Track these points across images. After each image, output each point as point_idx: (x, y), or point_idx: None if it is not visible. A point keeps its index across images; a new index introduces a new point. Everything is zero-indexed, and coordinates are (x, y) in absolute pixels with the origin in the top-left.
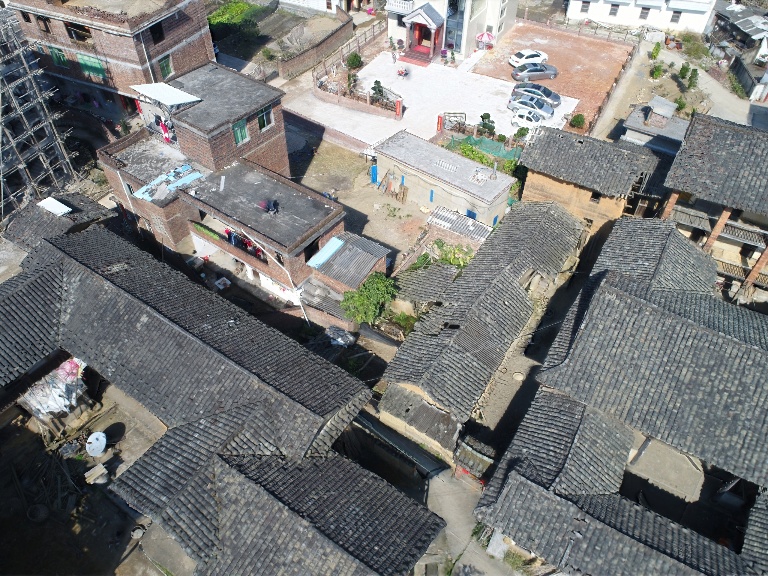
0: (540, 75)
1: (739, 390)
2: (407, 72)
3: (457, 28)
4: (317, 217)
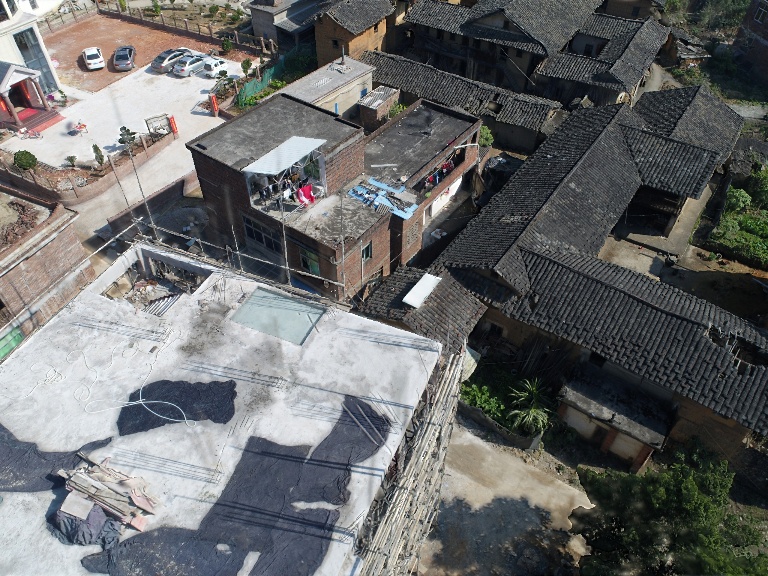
0: (133, 55)
1: (550, 2)
2: (70, 130)
3: (41, 66)
4: (431, 114)
